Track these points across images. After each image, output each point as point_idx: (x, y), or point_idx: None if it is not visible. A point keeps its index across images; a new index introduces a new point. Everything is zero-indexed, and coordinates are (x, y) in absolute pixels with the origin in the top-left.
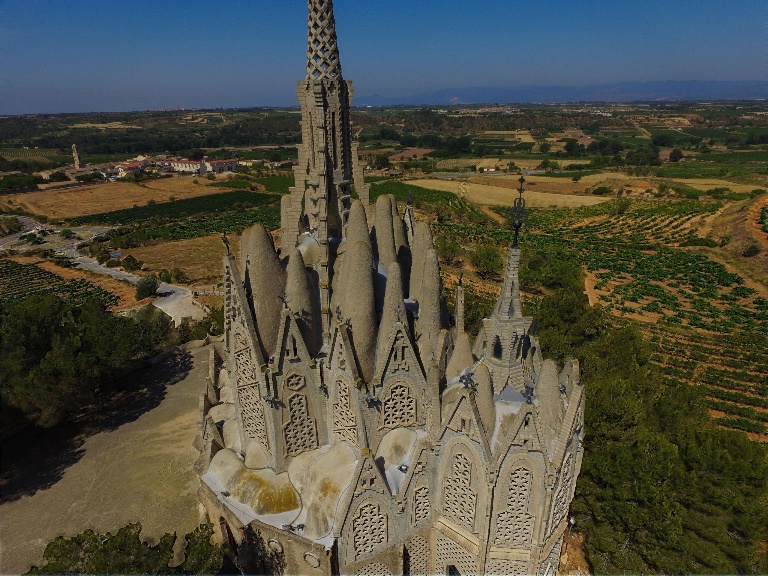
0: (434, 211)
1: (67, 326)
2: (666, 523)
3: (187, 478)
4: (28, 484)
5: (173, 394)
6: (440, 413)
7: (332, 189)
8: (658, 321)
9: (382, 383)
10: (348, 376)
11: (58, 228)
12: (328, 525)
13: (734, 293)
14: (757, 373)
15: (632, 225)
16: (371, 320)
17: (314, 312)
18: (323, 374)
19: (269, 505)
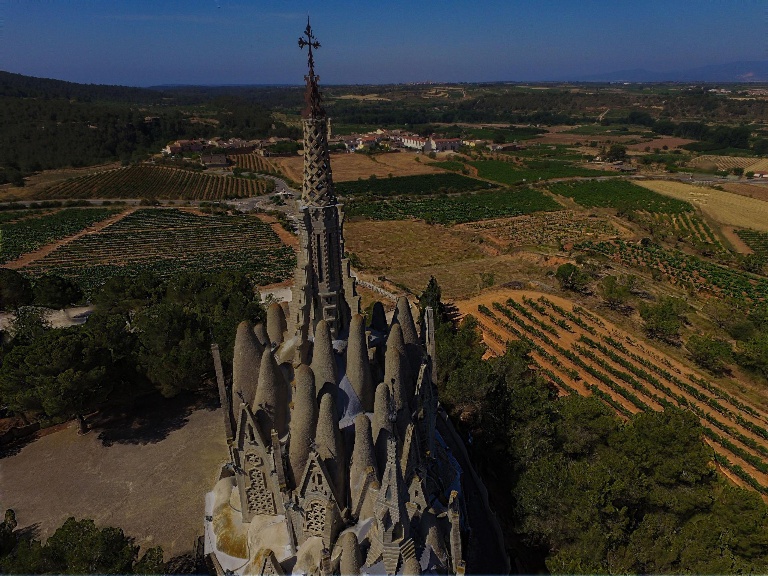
0: (647, 228)
1: (204, 320)
2: None
3: None
4: (147, 435)
5: None
6: (331, 551)
7: (318, 298)
8: None
9: (304, 496)
10: None
11: (297, 193)
12: None
13: None
14: None
15: None
16: (308, 435)
17: (282, 404)
18: None
19: (225, 546)
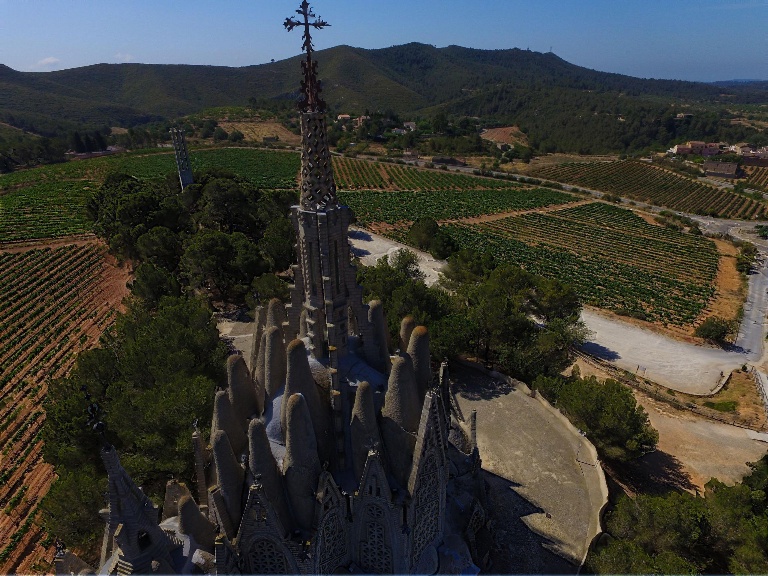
0: None
1: (442, 307)
2: None
3: None
4: None
5: None
6: None
7: None
8: None
9: None
10: None
11: None
12: None
13: None
14: None
15: None
16: None
17: None
18: None
19: None
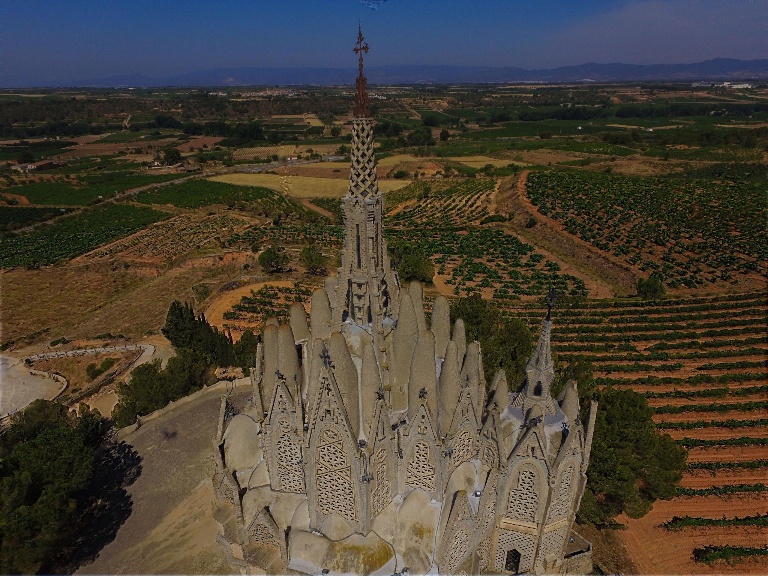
0: (262, 213)
1: None
2: (612, 464)
3: (223, 574)
4: None
5: (140, 495)
6: None
7: None
8: (494, 295)
9: None
10: (429, 438)
11: None
12: (429, 560)
13: (531, 260)
14: (572, 325)
15: (439, 207)
16: None
17: None
18: (399, 441)
19: (373, 565)
